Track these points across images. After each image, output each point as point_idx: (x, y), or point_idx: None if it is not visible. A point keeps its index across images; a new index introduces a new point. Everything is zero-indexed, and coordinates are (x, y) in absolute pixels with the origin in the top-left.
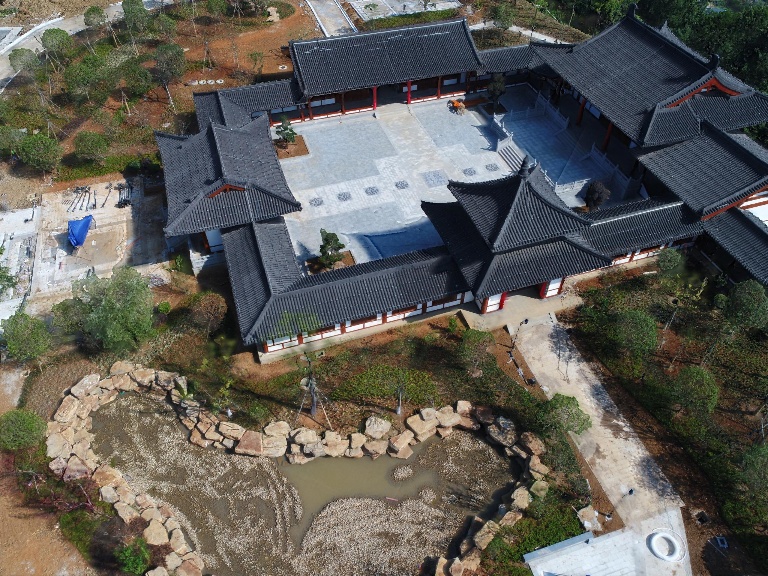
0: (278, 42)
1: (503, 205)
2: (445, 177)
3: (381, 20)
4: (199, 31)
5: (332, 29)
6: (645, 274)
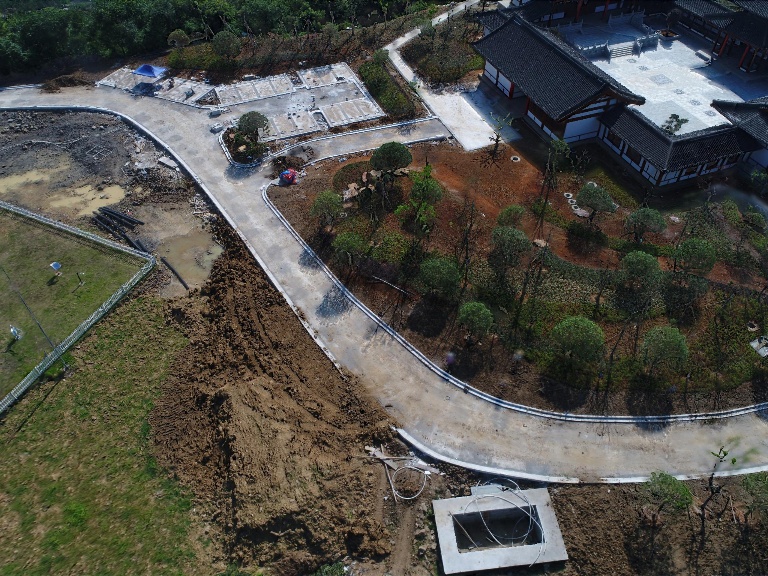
0: (462, 164)
1: None
2: (657, 76)
3: (395, 101)
4: (454, 225)
5: (402, 138)
6: None
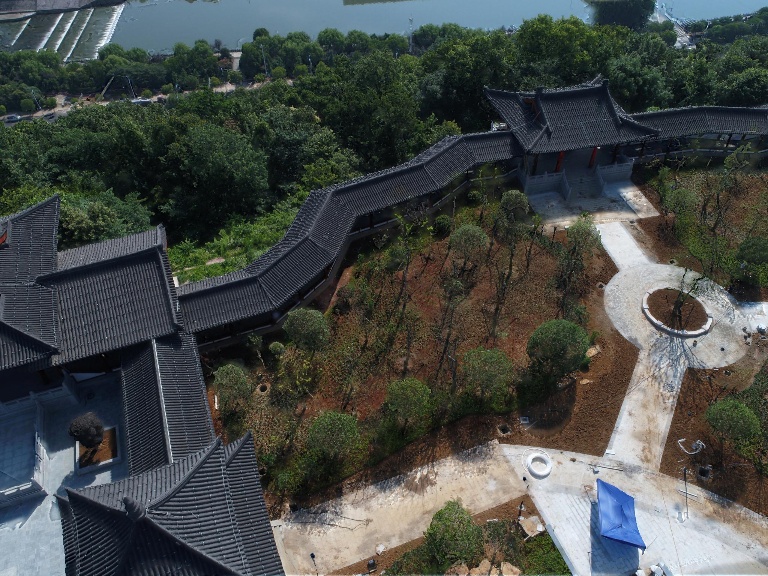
0: None
1: (166, 556)
2: None
3: None
4: None
5: None
6: (218, 408)
